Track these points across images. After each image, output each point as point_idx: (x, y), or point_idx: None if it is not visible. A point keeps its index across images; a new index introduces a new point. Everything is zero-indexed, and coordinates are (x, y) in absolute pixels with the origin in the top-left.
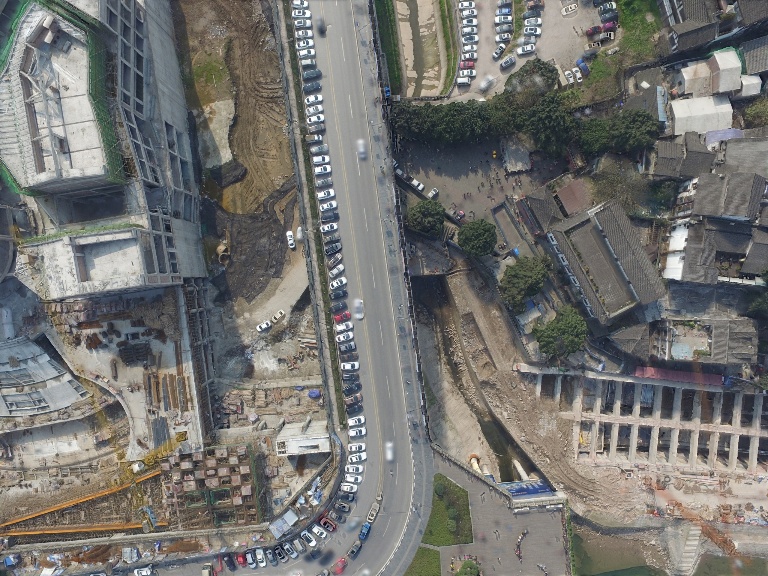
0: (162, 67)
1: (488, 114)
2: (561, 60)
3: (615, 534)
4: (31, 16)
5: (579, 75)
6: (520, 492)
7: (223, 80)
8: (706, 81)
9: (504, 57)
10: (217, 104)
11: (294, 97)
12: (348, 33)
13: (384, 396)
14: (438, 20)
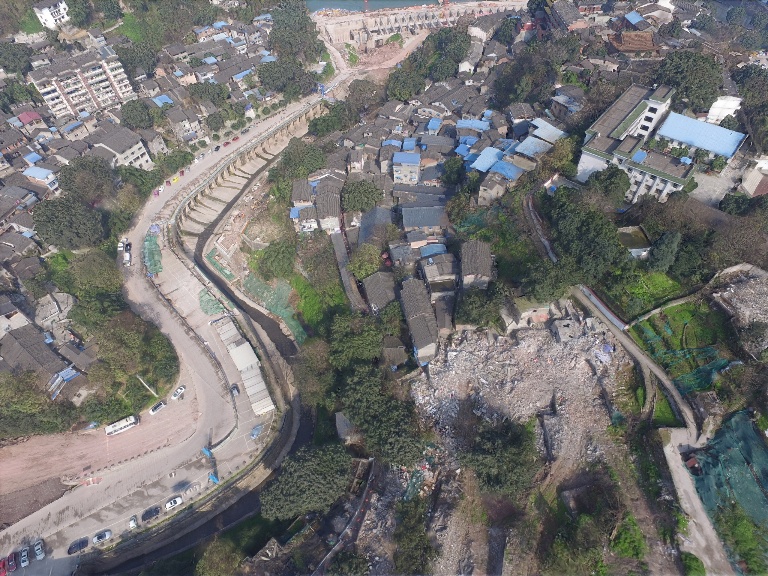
0: None
1: (762, 33)
2: None
3: None
4: None
5: None
6: None
7: None
8: None
9: None
10: None
11: None
12: None
13: None
14: None
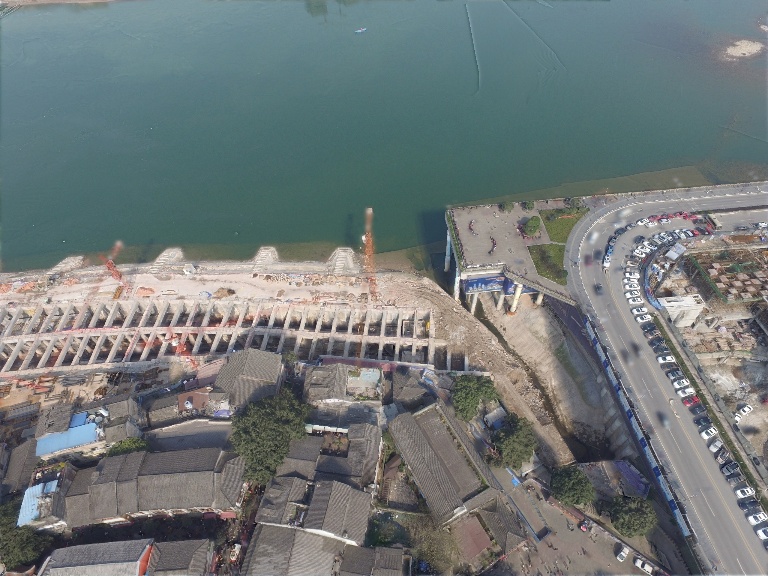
0: None
1: None
2: None
3: (391, 271)
4: None
5: None
6: (490, 280)
7: None
8: None
9: None
10: None
11: None
12: None
13: (626, 337)
14: None
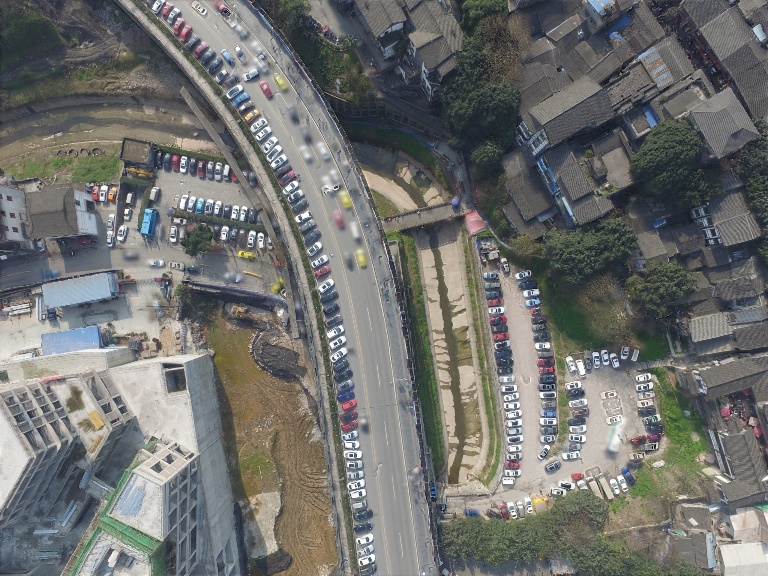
0: (213, 494)
1: (537, 547)
2: (606, 466)
3: None
4: (96, 547)
5: (624, 486)
6: None
7: (269, 472)
8: (755, 531)
9: (549, 458)
10: (263, 496)
11: (345, 536)
12: (399, 472)
13: None
14: (480, 392)
